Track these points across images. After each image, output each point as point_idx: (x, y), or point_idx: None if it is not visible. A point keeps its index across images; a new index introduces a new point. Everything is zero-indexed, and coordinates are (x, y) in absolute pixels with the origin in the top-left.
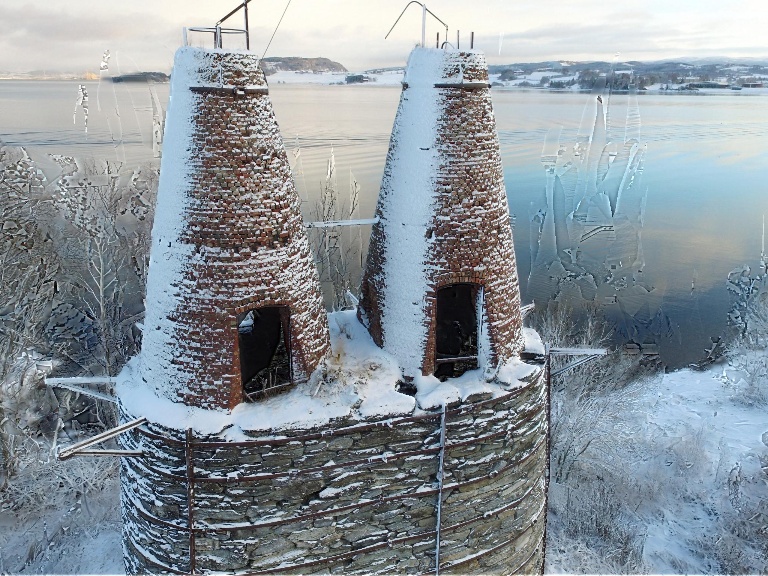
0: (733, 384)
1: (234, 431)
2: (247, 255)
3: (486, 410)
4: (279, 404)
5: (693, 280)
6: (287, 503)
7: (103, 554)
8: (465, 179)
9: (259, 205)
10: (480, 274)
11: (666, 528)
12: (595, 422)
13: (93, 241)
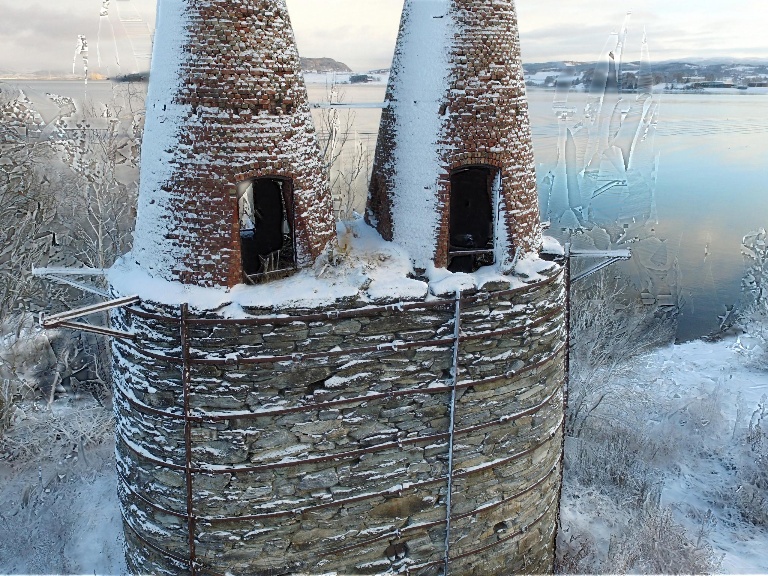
0: (748, 350)
1: (233, 308)
2: (247, 117)
3: (503, 302)
4: (281, 284)
5: (706, 245)
6: (290, 391)
7: (99, 496)
8: (482, 49)
9: (260, 64)
10: (497, 156)
11: (683, 481)
12: (608, 376)
13: (92, 187)
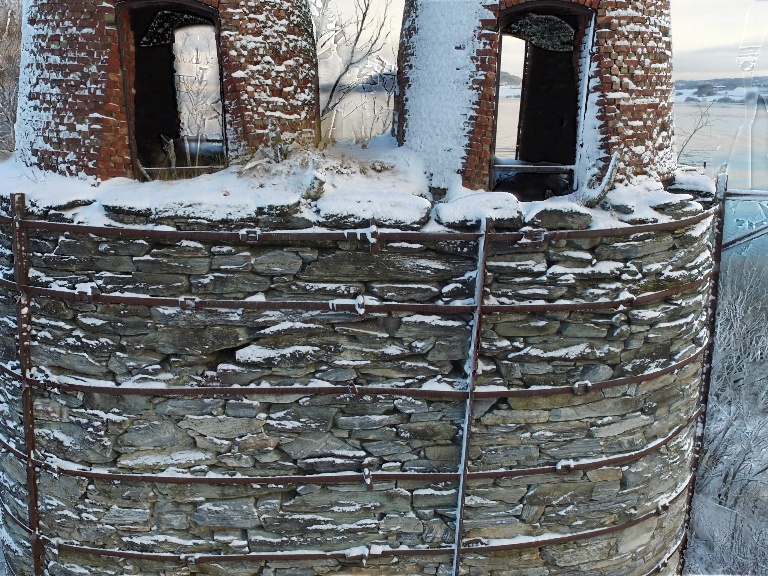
0: None
1: (90, 208)
2: None
3: (575, 251)
4: (181, 180)
5: None
6: (177, 359)
7: None
8: None
9: None
10: None
11: None
12: None
13: None
